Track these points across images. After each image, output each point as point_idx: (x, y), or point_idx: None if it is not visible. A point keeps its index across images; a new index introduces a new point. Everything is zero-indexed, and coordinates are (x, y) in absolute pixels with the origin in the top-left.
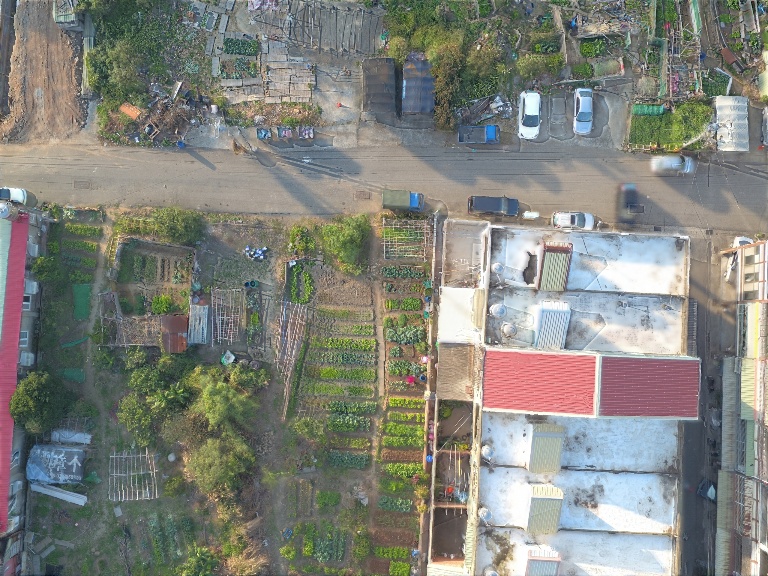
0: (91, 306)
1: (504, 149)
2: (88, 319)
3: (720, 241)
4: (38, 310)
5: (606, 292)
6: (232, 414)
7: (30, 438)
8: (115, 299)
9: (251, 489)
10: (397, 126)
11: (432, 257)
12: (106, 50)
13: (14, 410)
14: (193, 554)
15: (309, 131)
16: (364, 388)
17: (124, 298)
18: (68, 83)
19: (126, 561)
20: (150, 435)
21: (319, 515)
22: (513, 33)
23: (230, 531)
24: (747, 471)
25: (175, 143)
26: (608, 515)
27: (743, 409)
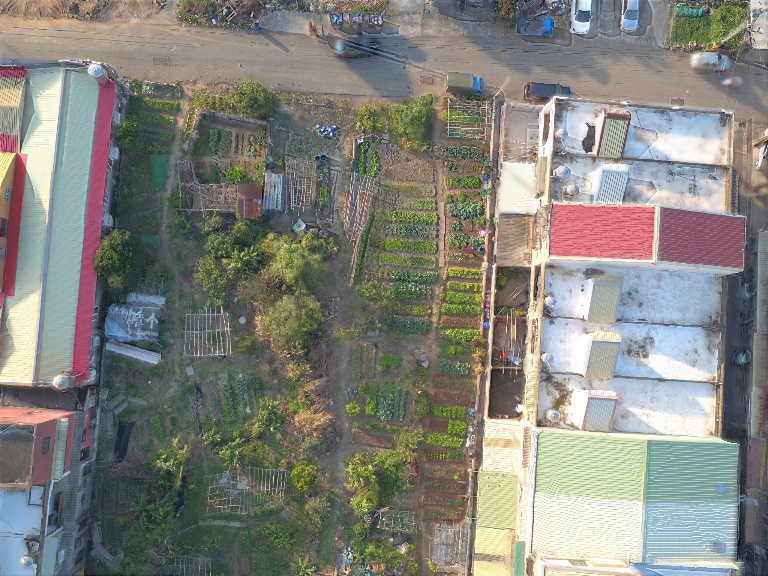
0: (167, 176)
1: (557, 43)
2: (164, 188)
3: (752, 134)
4: (117, 177)
5: (658, 161)
6: (308, 270)
7: (107, 298)
8: (192, 168)
9: (319, 350)
10: (458, 18)
11: (490, 139)
12: None
13: (99, 262)
14: (265, 407)
15: (378, 18)
16: (426, 259)
17: (199, 169)
18: None
19: (197, 417)
20: (225, 294)
21: (382, 377)
22: None
23: (298, 389)
24: None
25: (250, 26)
26: (658, 365)
27: None
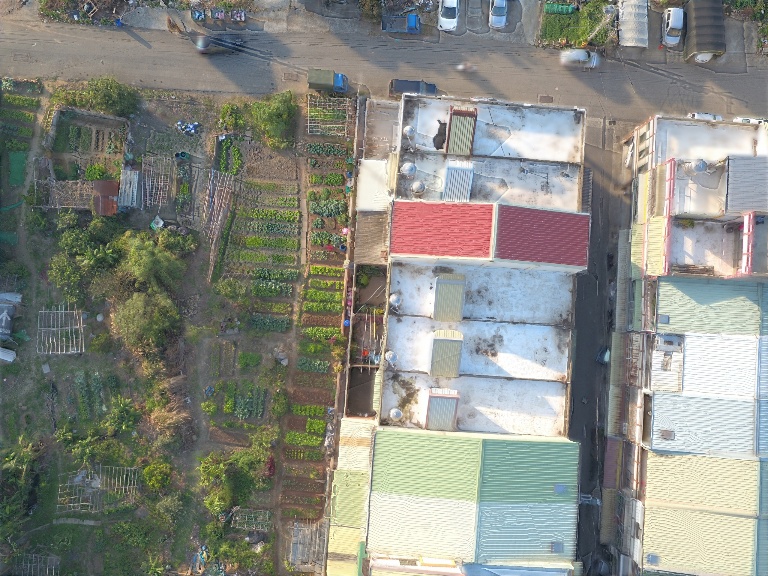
0: (26, 173)
1: (424, 40)
2: (23, 185)
3: (622, 131)
4: None
5: (509, 158)
6: (157, 267)
7: None
8: (49, 164)
9: (176, 348)
10: (325, 15)
11: (354, 136)
12: None
13: None
14: (117, 405)
15: (241, 14)
16: (287, 256)
17: (59, 166)
18: None
19: (52, 415)
20: (79, 292)
21: (241, 375)
22: None
23: (154, 387)
24: (635, 326)
25: (113, 22)
26: (507, 363)
27: (633, 271)
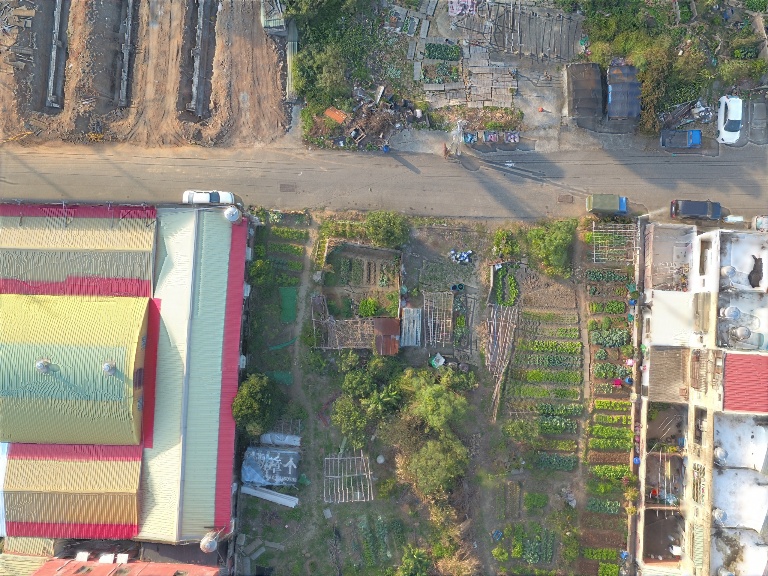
0: (298, 309)
1: (703, 153)
2: (295, 322)
3: None
4: (247, 313)
5: None
6: (455, 416)
7: (241, 440)
8: (325, 302)
9: (461, 491)
10: (598, 131)
11: (636, 260)
12: (312, 55)
13: (238, 412)
14: (410, 556)
15: (514, 135)
16: (570, 390)
17: (331, 301)
18: (273, 87)
19: (337, 563)
20: (365, 437)
21: (527, 517)
22: (712, 39)
23: (441, 533)
24: None
25: (379, 147)
26: None
27: None
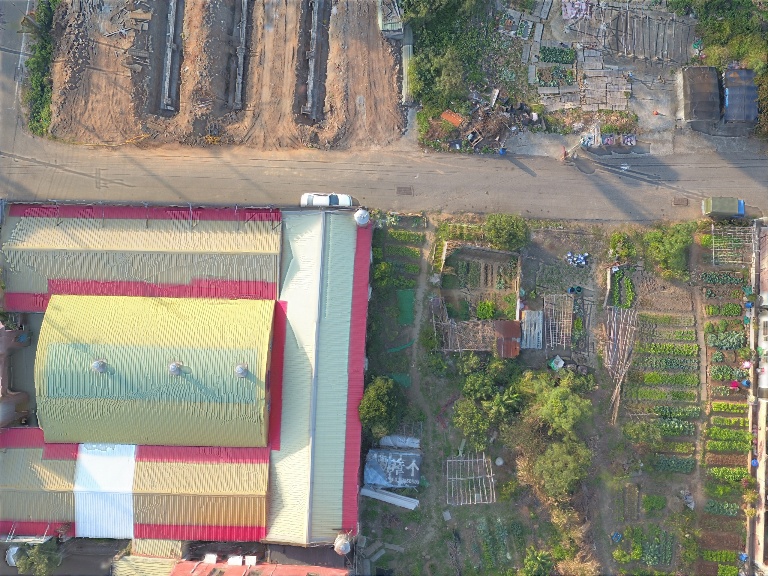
0: (415, 311)
1: None
2: (413, 324)
3: None
4: None
5: None
6: (582, 418)
7: None
8: None
9: (580, 493)
10: (712, 134)
11: None
12: (429, 58)
13: (366, 414)
14: (533, 558)
15: (631, 138)
16: (687, 393)
17: (449, 303)
18: (390, 90)
19: (457, 565)
20: (487, 439)
21: (646, 519)
22: None
23: (562, 535)
24: None
25: (495, 150)
26: None
27: None
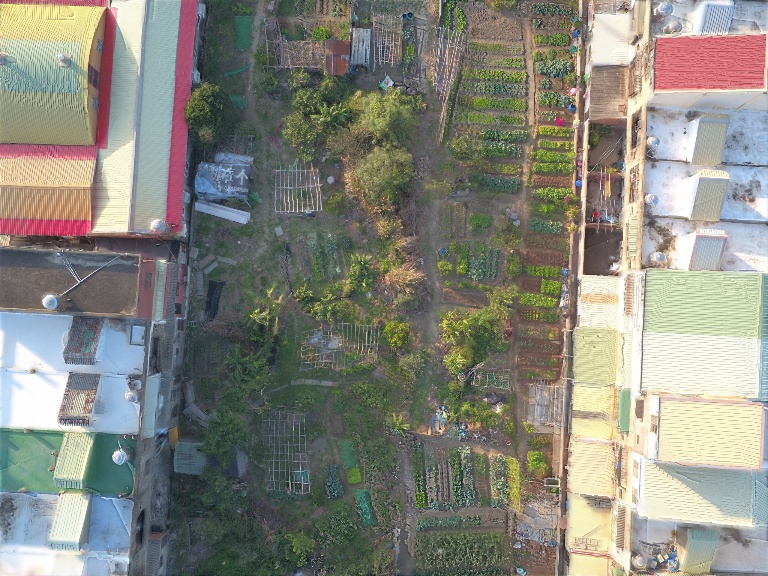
0: (253, 37)
1: None
2: (250, 49)
3: None
4: (203, 38)
5: None
6: (400, 120)
7: (195, 158)
8: None
9: (408, 209)
10: None
11: None
12: None
13: (191, 114)
14: (357, 262)
15: None
16: (515, 117)
17: (285, 29)
18: None
19: (287, 276)
20: (315, 151)
21: (473, 236)
22: None
23: (389, 247)
24: None
25: None
26: (765, 209)
27: None
